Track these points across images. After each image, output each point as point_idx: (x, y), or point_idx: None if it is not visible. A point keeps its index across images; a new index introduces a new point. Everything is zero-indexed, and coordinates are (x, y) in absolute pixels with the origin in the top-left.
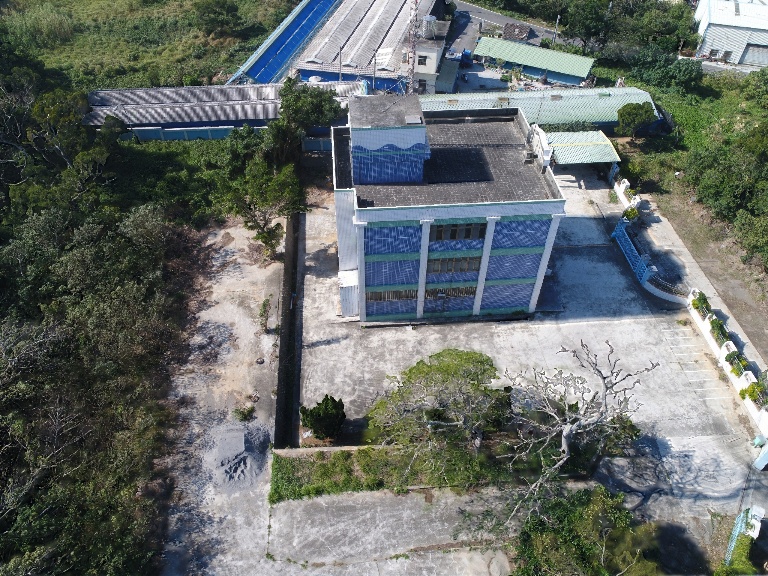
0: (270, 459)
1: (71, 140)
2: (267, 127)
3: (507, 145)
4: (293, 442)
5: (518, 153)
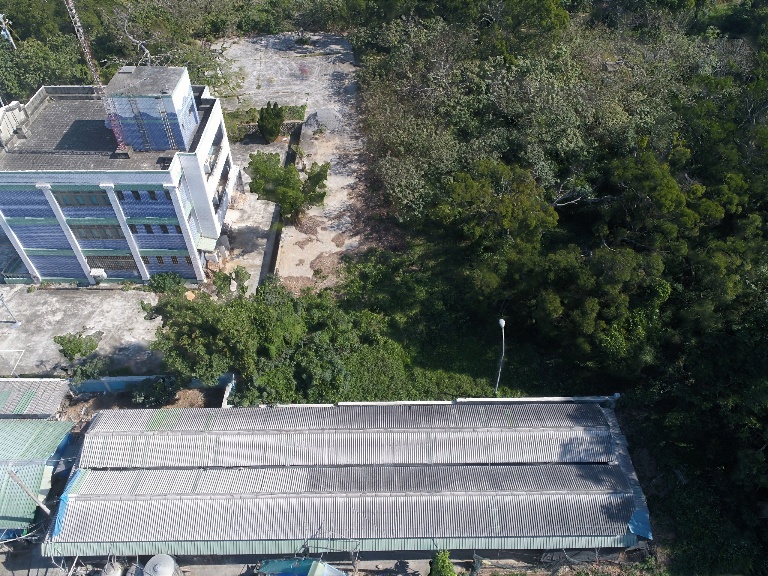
0: (305, 118)
1: (519, 245)
2: (284, 405)
3: (25, 152)
4: (294, 136)
5: (25, 143)
